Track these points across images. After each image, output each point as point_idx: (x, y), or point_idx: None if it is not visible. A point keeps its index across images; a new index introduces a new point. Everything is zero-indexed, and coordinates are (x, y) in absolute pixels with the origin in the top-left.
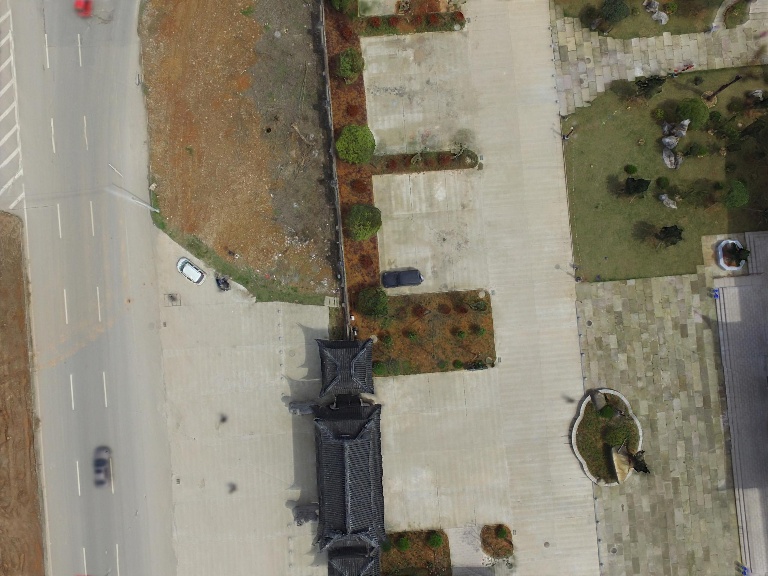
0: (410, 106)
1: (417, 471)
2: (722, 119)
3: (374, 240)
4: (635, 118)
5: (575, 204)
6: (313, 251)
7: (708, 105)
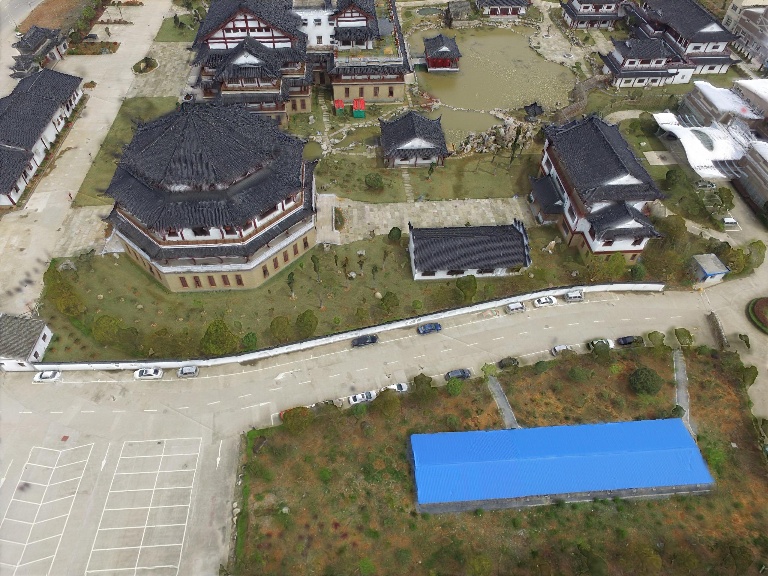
0: None
1: None
2: None
3: (87, 33)
4: None
5: (161, 30)
6: None
7: None
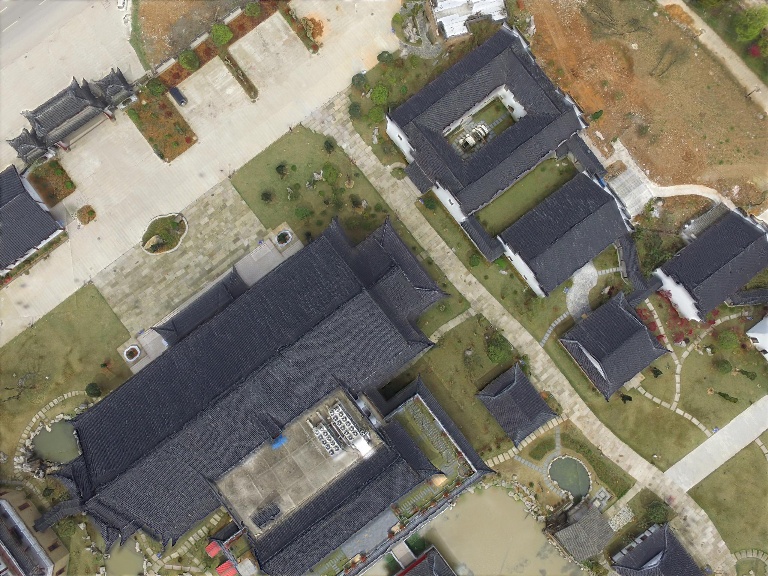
0: (261, 53)
1: (96, 159)
2: (344, 195)
3: (189, 74)
4: (320, 156)
5: (264, 154)
6: (168, 51)
7: (347, 185)
